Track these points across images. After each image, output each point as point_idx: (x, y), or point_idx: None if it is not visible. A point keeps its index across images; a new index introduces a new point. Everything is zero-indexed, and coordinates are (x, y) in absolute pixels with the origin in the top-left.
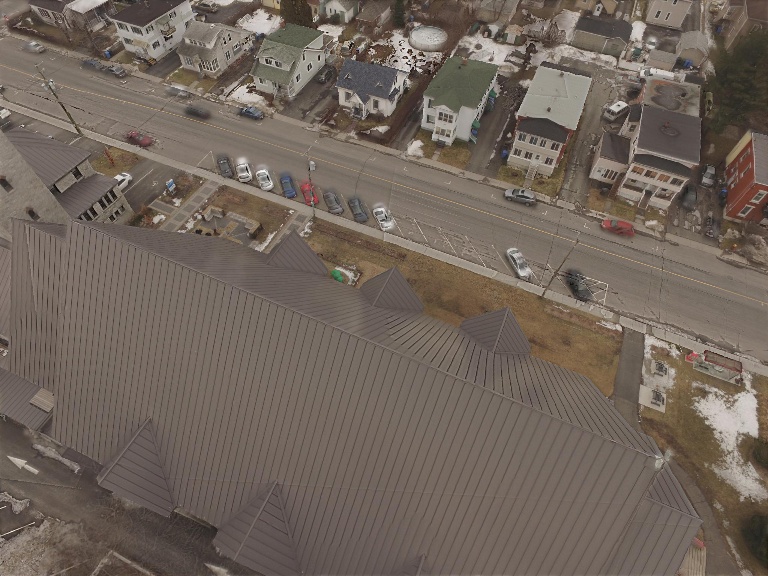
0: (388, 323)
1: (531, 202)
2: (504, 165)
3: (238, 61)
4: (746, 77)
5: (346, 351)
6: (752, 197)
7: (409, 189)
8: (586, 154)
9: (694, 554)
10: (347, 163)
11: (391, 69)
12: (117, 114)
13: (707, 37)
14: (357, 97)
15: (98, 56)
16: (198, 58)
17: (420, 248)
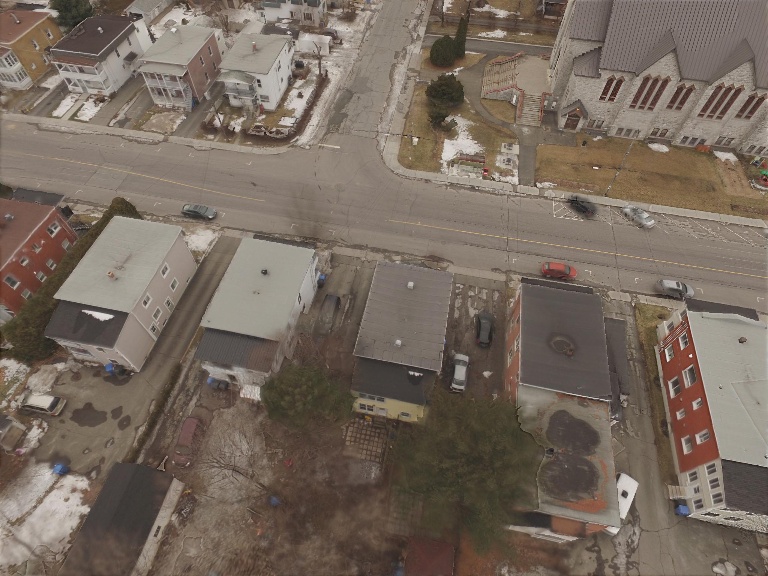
0: (739, 1)
1: None
2: None
3: None
4: None
5: None
6: None
7: None
8: None
9: None
10: None
11: None
12: None
13: None
14: None
15: None
16: None
17: (727, 218)
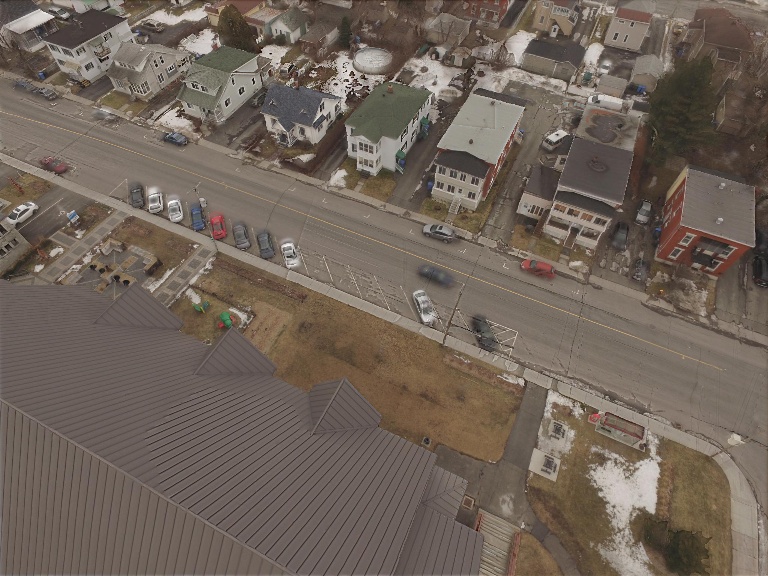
0: (180, 404)
1: (449, 239)
2: (428, 198)
3: (174, 83)
4: (680, 110)
5: (67, 457)
6: (680, 239)
7: (324, 223)
8: (518, 186)
9: None
10: (264, 193)
11: (317, 95)
12: (39, 138)
13: (667, 60)
14: (280, 124)
15: (33, 77)
16: (127, 81)
17: (323, 288)
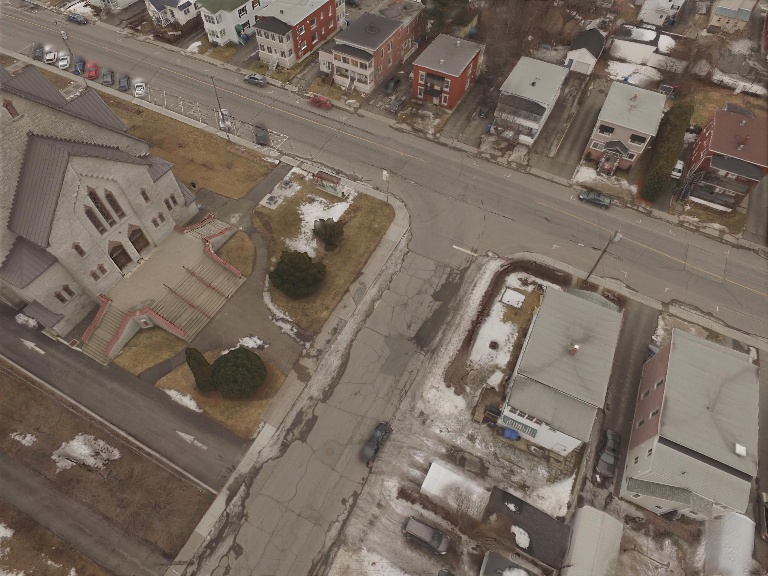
0: None
1: (260, 83)
2: (258, 60)
3: None
4: None
5: None
6: (418, 78)
7: (172, 72)
8: None
9: (231, 278)
10: (134, 54)
11: None
12: None
13: None
14: (152, 5)
15: None
16: None
17: (157, 108)
